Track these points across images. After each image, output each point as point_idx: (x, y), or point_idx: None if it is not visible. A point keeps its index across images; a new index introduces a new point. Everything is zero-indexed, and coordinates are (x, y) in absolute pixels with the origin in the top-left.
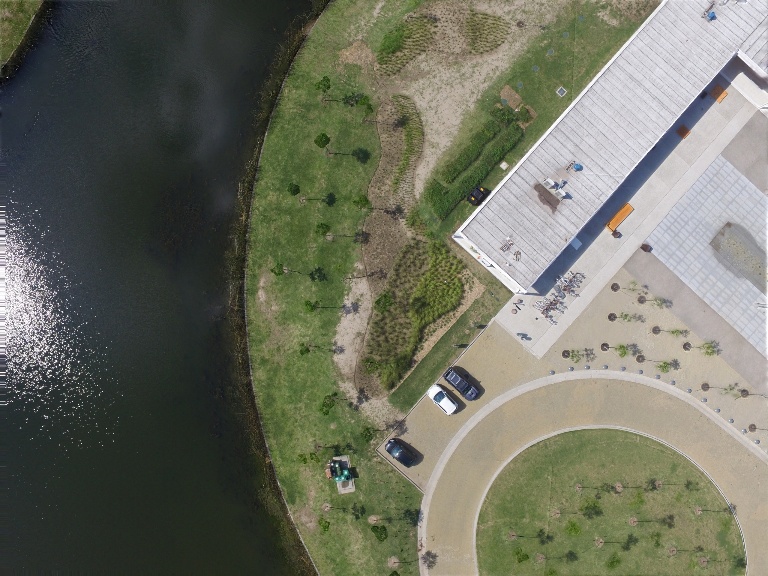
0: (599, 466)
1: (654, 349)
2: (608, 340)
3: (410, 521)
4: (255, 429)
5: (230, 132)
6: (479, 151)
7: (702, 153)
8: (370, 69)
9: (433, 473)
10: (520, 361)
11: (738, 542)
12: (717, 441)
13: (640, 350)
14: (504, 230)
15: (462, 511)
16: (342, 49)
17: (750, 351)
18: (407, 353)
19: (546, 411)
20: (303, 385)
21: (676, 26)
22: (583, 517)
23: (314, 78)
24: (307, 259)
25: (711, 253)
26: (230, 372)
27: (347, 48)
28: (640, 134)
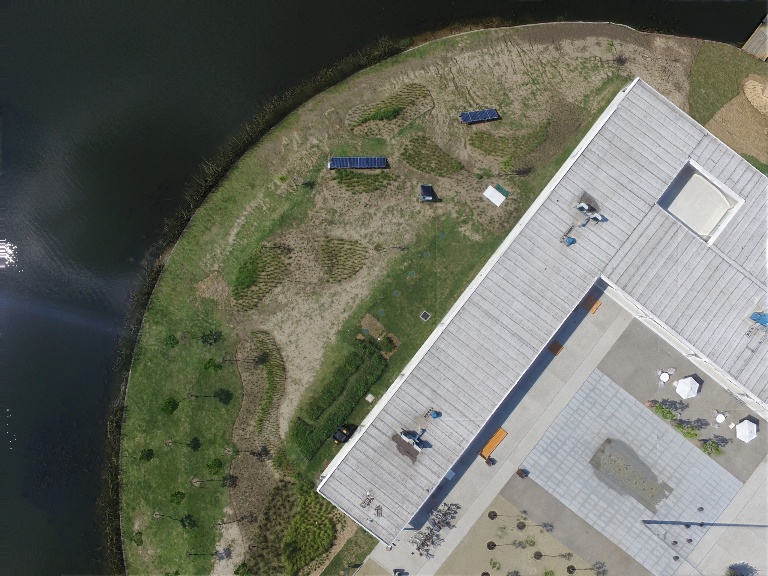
0: None
1: (537, 574)
2: (488, 569)
3: None
4: None
5: (95, 370)
6: (342, 386)
7: (577, 368)
8: (227, 305)
9: None
10: None
11: None
12: None
13: None
14: (363, 485)
15: None
16: (199, 281)
17: (637, 569)
18: None
19: None
20: None
21: (533, 254)
22: None
23: (173, 313)
24: None
25: (591, 472)
26: None
27: (204, 280)
28: (500, 373)
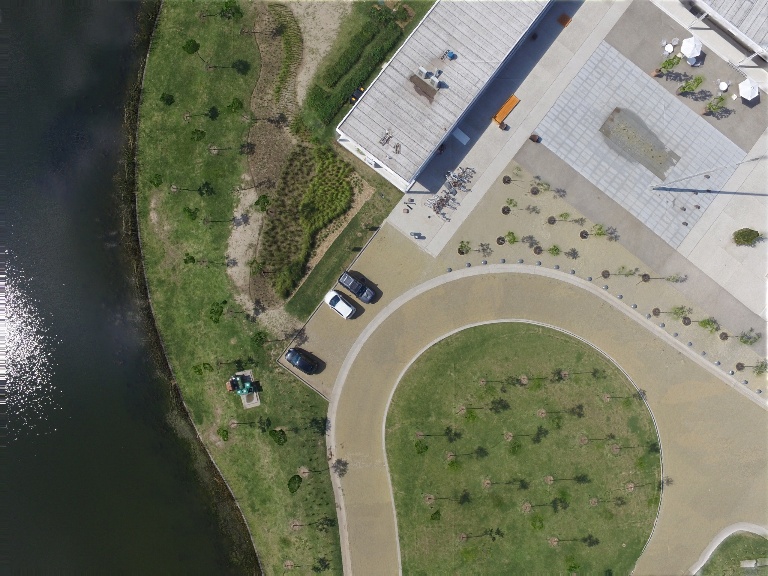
0: (502, 359)
1: (551, 239)
2: (503, 234)
3: (317, 430)
4: (158, 353)
5: (112, 58)
6: (359, 53)
7: (585, 40)
8: None
9: (337, 380)
10: (416, 261)
11: (650, 427)
12: (621, 327)
13: (537, 241)
14: (382, 124)
15: (369, 416)
16: None
17: (648, 235)
18: (299, 259)
19: (446, 309)
20: (200, 303)
21: None
22: (490, 412)
23: None
24: (194, 175)
25: (601, 139)
26: (129, 298)
27: None
28: (513, 18)
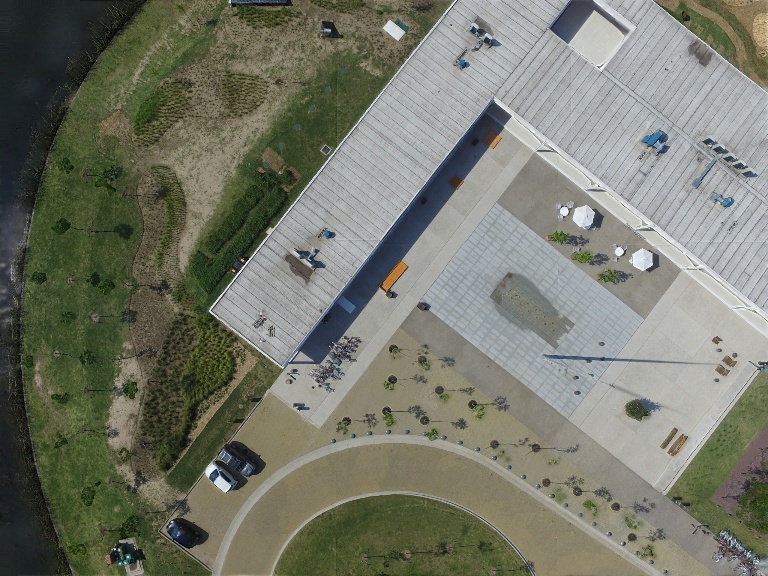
0: (385, 534)
1: (438, 409)
2: (389, 404)
3: None
4: (45, 515)
5: None
6: (242, 219)
7: (477, 203)
8: (128, 140)
9: (219, 550)
10: (299, 432)
11: None
12: (510, 498)
13: (423, 411)
14: (256, 305)
15: None
16: (102, 120)
17: (539, 404)
18: (179, 433)
19: (329, 481)
20: (84, 469)
21: (427, 77)
22: None
23: (75, 153)
24: (76, 342)
25: (492, 306)
26: (16, 458)
27: (107, 119)
28: (393, 194)
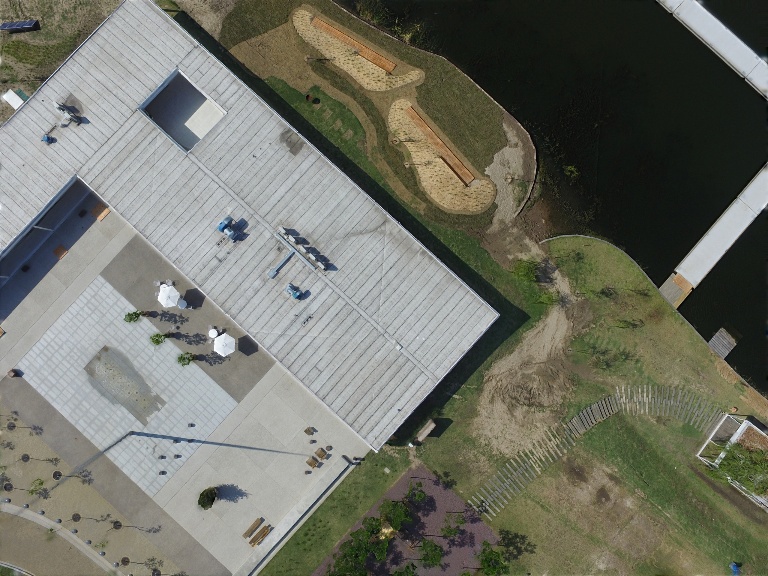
0: None
1: (23, 477)
2: None
3: None
4: None
5: None
6: None
7: (80, 274)
8: None
9: None
10: None
11: None
12: (87, 574)
13: (8, 478)
14: None
15: None
16: None
17: (124, 481)
18: None
19: None
20: None
21: (13, 150)
22: None
23: None
24: None
25: (86, 378)
26: None
27: None
28: None
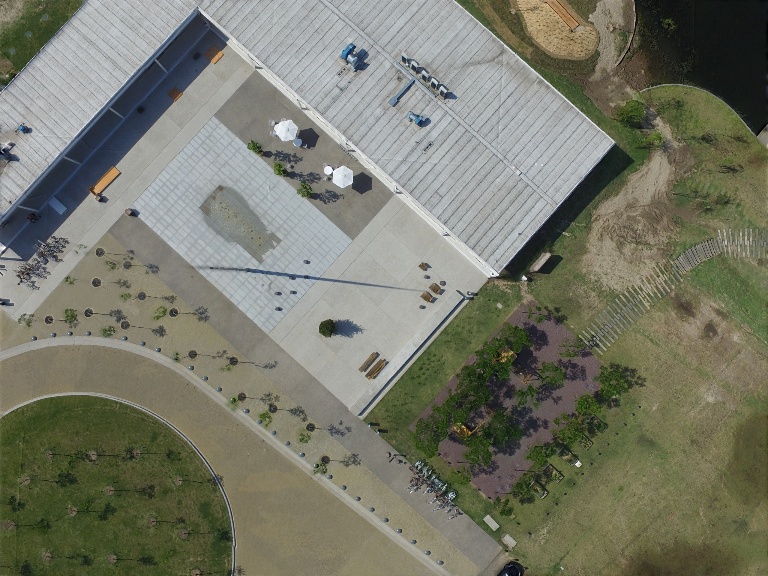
0: (73, 433)
1: (139, 315)
2: (92, 306)
3: None
4: None
5: None
6: None
7: (194, 115)
8: None
9: None
10: (2, 327)
11: (223, 514)
12: (204, 410)
13: (124, 316)
14: None
15: None
16: None
17: (240, 317)
18: None
19: (27, 377)
20: None
21: None
22: (56, 484)
23: None
24: None
25: (201, 217)
26: None
27: None
28: (91, 94)
